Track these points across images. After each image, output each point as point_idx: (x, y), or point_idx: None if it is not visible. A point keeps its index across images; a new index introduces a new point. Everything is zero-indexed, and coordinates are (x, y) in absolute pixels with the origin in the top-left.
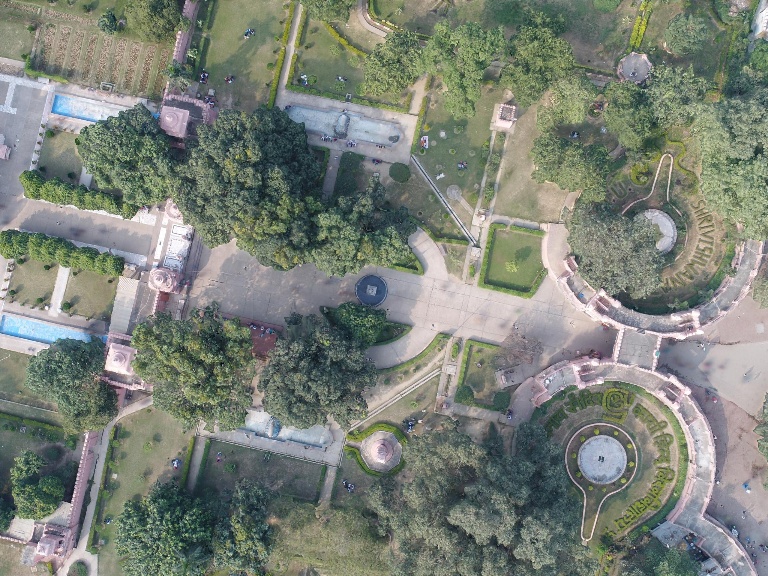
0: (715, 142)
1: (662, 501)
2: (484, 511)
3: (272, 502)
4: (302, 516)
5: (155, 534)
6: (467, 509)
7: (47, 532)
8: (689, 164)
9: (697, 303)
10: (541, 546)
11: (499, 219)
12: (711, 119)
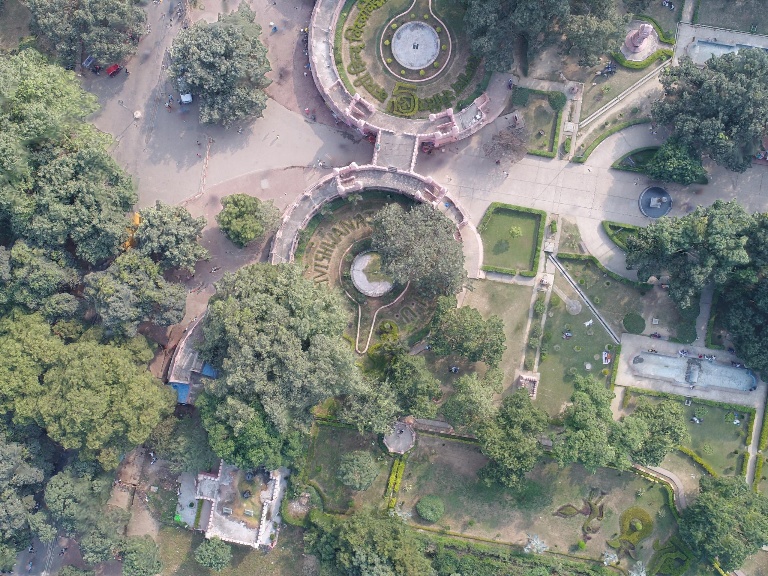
0: None
1: (357, 8)
2: None
3: None
4: None
5: None
6: None
7: None
8: None
9: None
10: None
11: (528, 282)
12: None
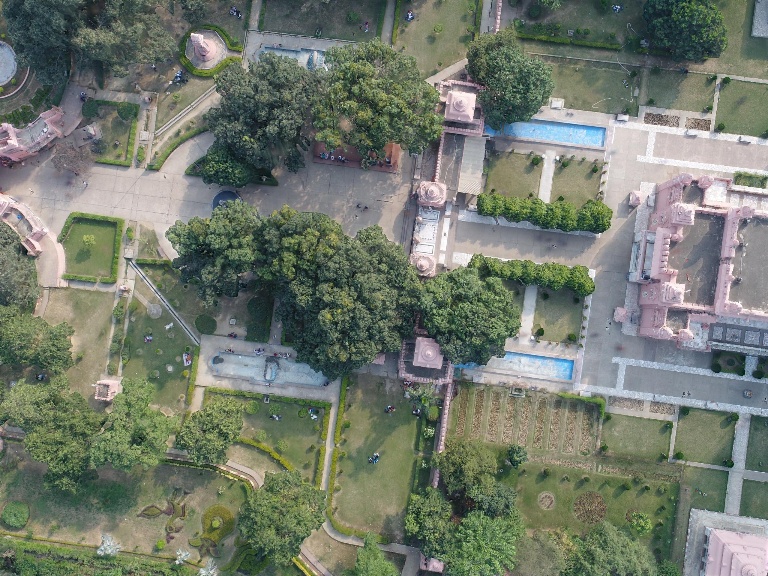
0: None
1: None
2: None
3: None
4: None
5: None
6: None
7: None
8: None
9: None
10: None
11: (109, 288)
12: None
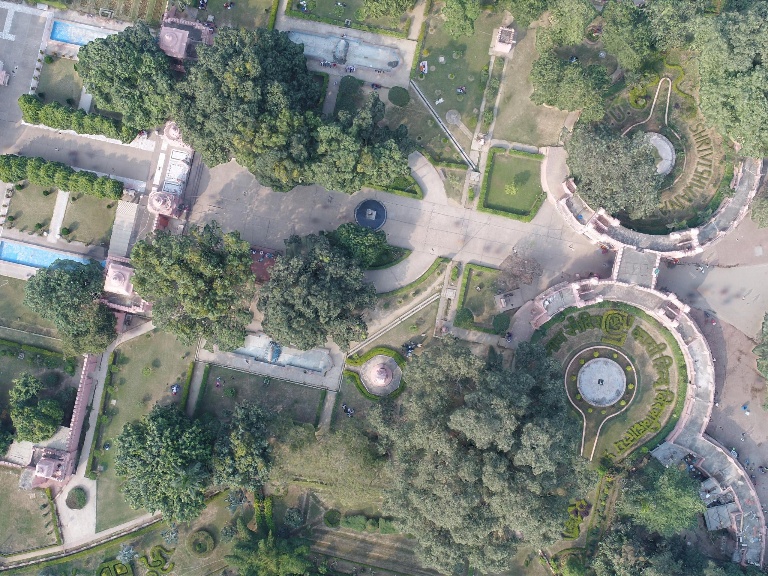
0: (713, 54)
1: (661, 423)
2: (484, 415)
3: (272, 422)
4: (302, 434)
5: (154, 450)
6: (467, 413)
7: (46, 456)
8: (687, 88)
9: (696, 225)
10: (541, 451)
11: (498, 143)
12: (709, 32)
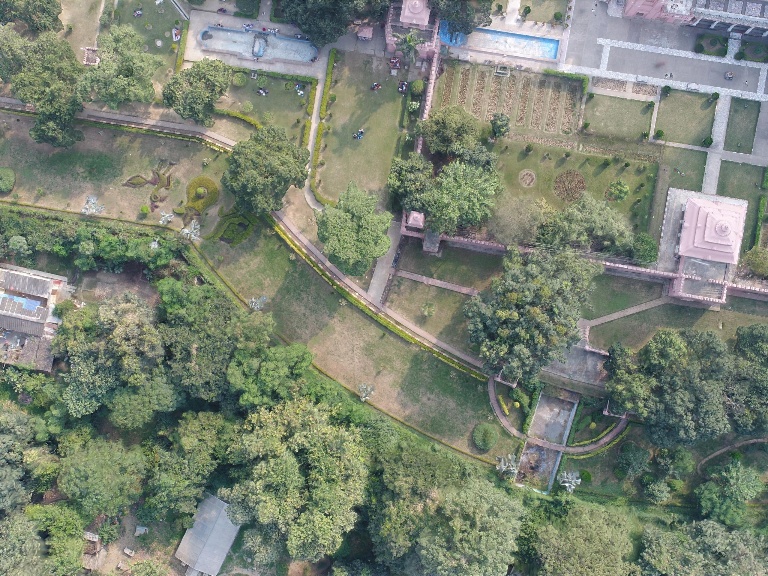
0: None
1: None
2: None
3: None
4: None
5: None
6: None
7: None
8: None
9: None
10: None
11: None
12: None
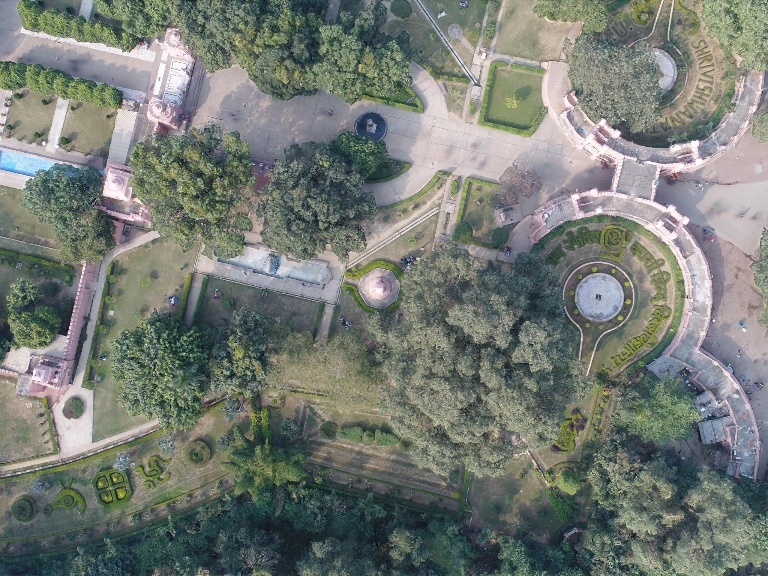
0: None
1: (658, 338)
2: (483, 310)
3: (269, 330)
4: (300, 340)
5: (152, 352)
6: (466, 307)
7: (43, 363)
8: (690, 4)
9: None
10: (539, 348)
11: (500, 58)
12: None
